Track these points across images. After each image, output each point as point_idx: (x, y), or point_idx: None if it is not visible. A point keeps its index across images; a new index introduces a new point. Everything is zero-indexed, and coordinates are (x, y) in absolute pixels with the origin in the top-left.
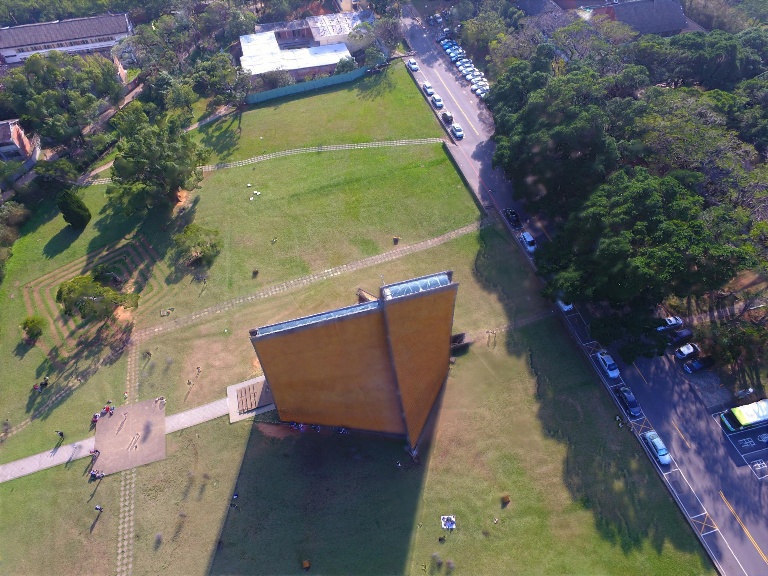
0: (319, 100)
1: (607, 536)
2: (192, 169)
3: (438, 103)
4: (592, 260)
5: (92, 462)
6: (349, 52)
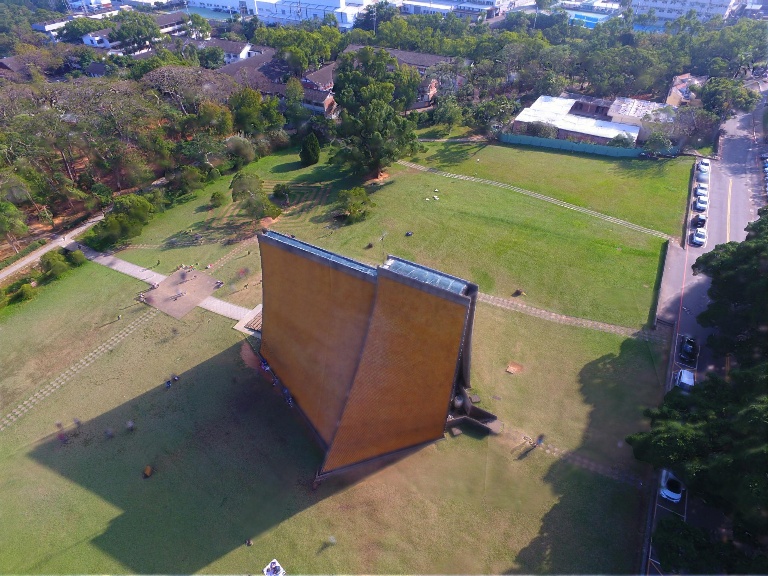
0: (566, 159)
1: None
2: (401, 156)
3: (700, 204)
4: (737, 431)
5: (149, 289)
6: (638, 135)
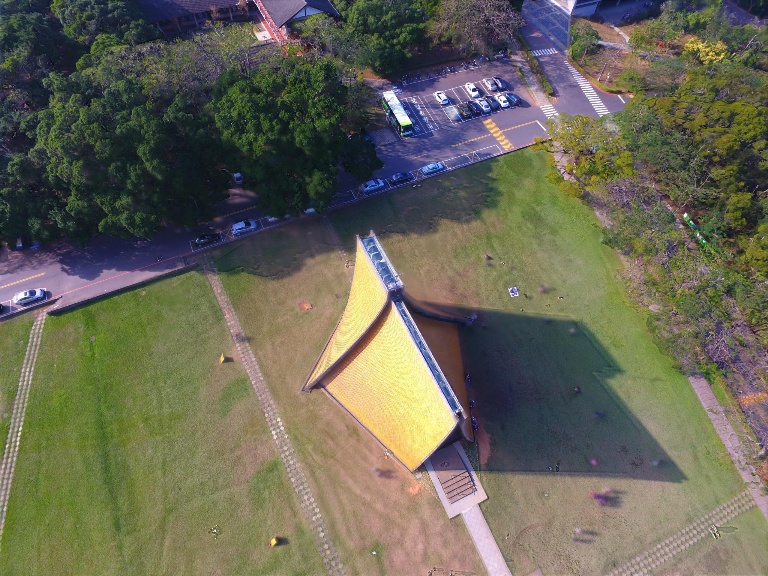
0: None
1: (494, 203)
2: None
3: None
4: (303, 161)
5: None
6: None
